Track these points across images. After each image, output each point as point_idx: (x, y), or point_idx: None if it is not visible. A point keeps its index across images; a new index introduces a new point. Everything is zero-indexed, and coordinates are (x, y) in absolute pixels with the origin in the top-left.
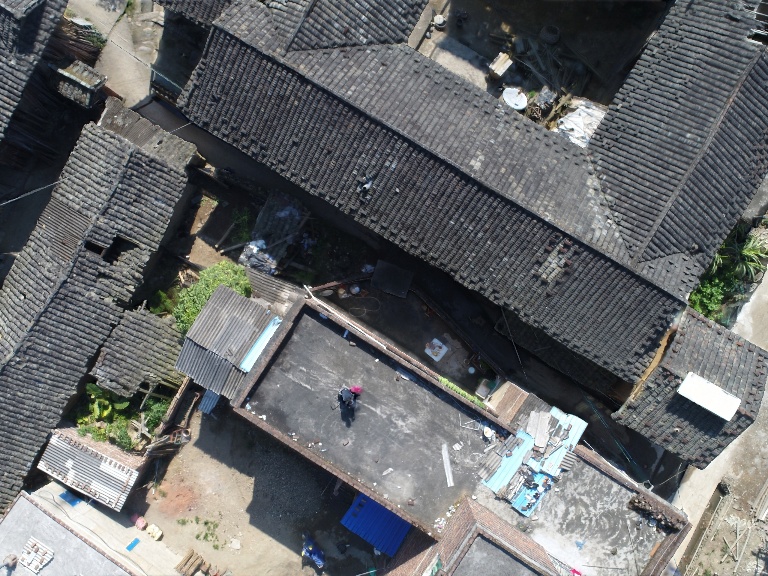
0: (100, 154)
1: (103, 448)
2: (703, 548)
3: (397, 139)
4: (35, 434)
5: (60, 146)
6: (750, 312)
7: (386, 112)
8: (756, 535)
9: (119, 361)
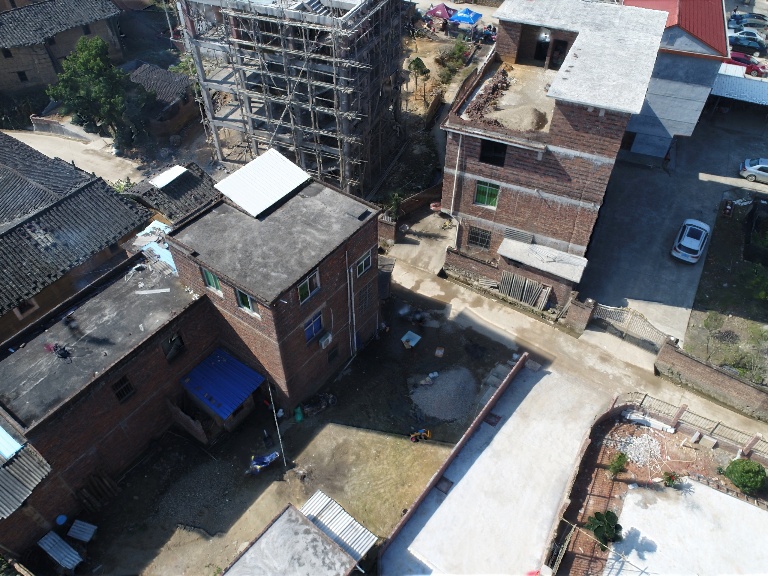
0: None
1: None
2: None
3: None
4: None
5: None
6: None
7: None
8: None
9: None
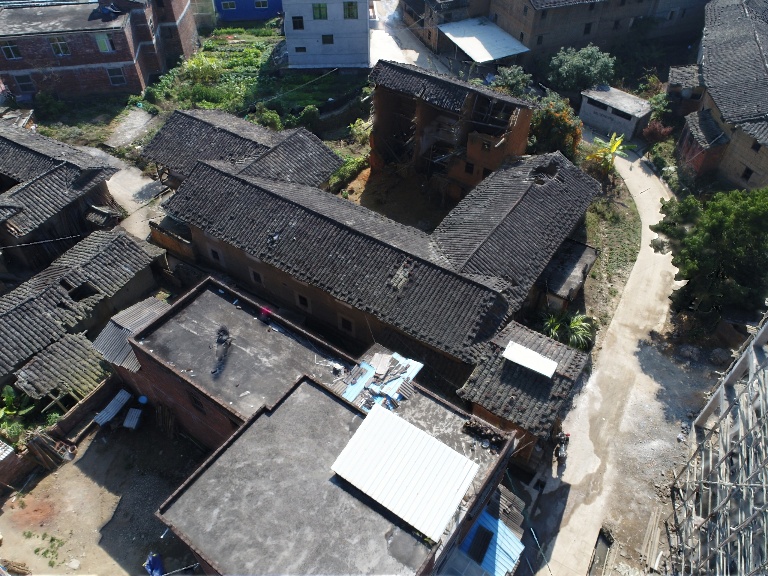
0: None
1: None
2: None
3: (298, 209)
4: None
5: None
6: (596, 383)
7: (294, 199)
8: None
9: (43, 368)
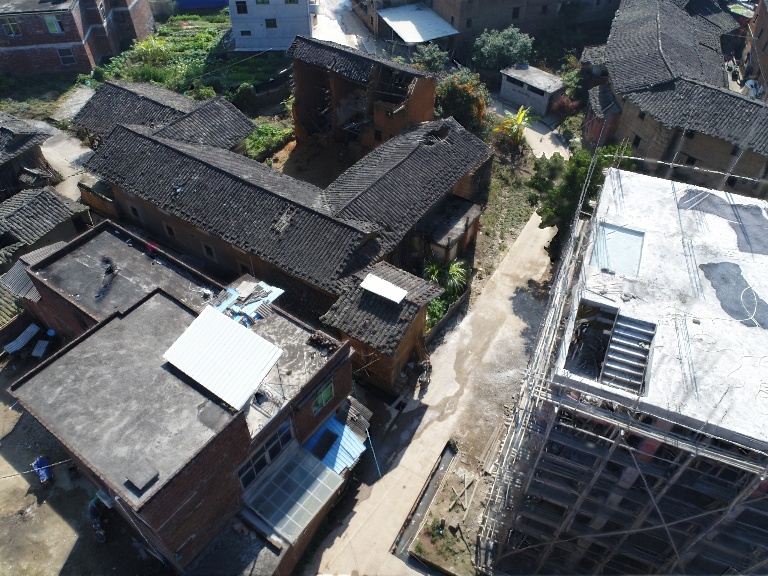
0: None
1: None
2: (434, 500)
3: (200, 164)
4: None
5: None
6: (469, 322)
7: None
8: (485, 488)
9: None
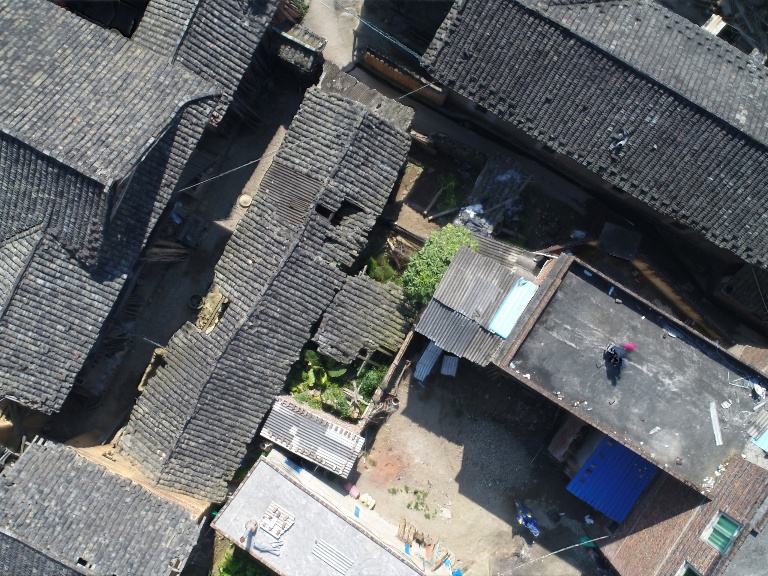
0: (327, 117)
1: (323, 415)
2: None
3: (662, 93)
4: (261, 400)
5: (263, 114)
6: None
7: (649, 66)
8: None
9: (340, 327)
